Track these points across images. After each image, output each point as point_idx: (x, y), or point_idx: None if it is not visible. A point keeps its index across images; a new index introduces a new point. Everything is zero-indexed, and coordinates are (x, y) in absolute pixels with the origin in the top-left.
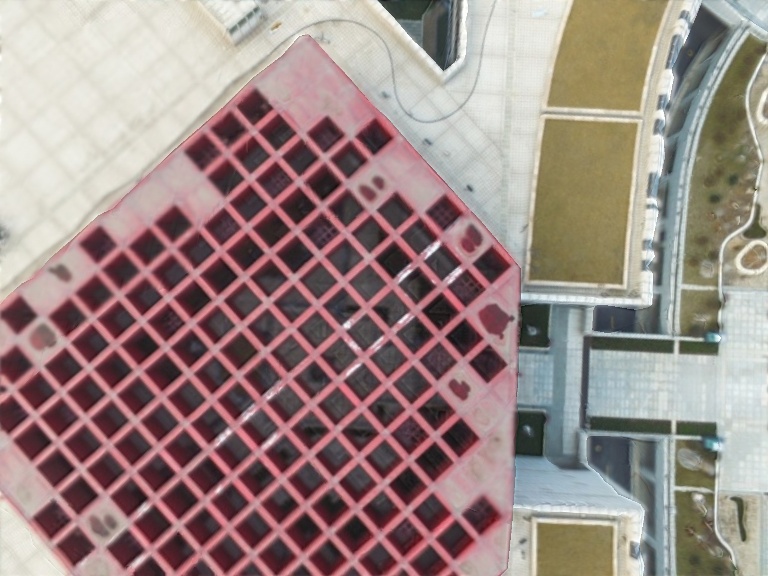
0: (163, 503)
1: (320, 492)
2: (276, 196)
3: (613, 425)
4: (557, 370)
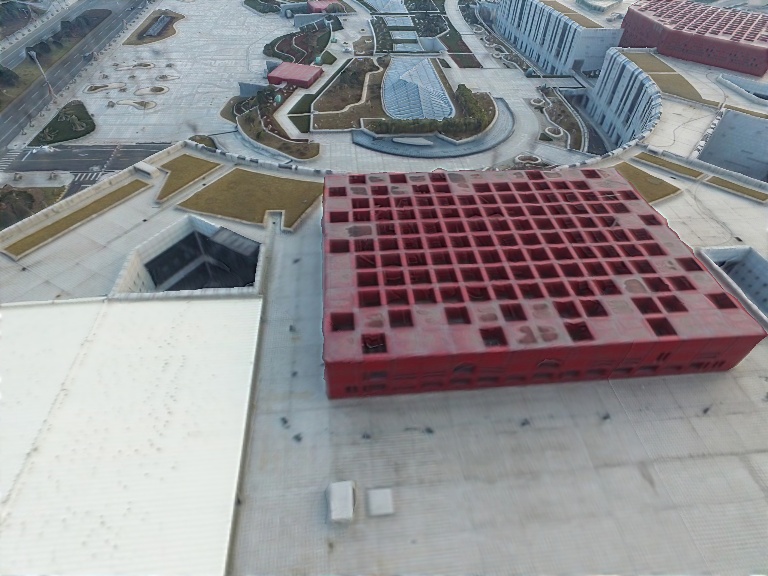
0: None
1: None
2: None
3: (563, 76)
4: None
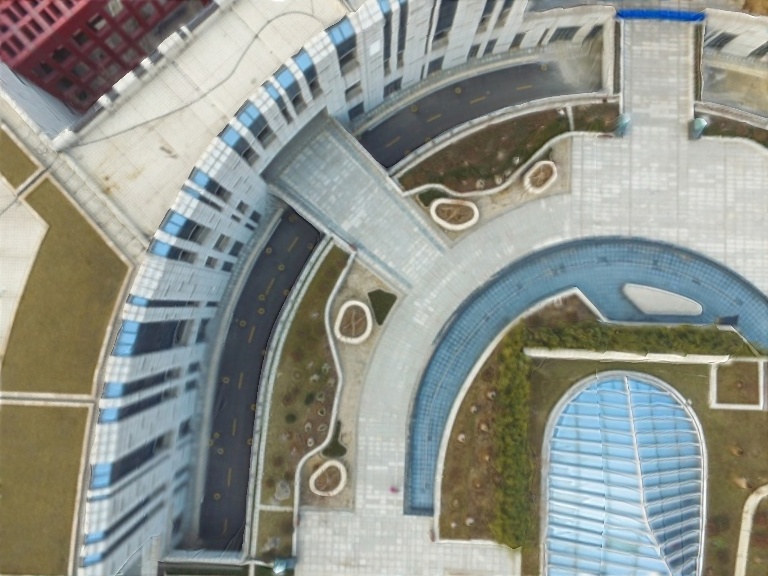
0: None
1: None
2: None
3: None
4: None
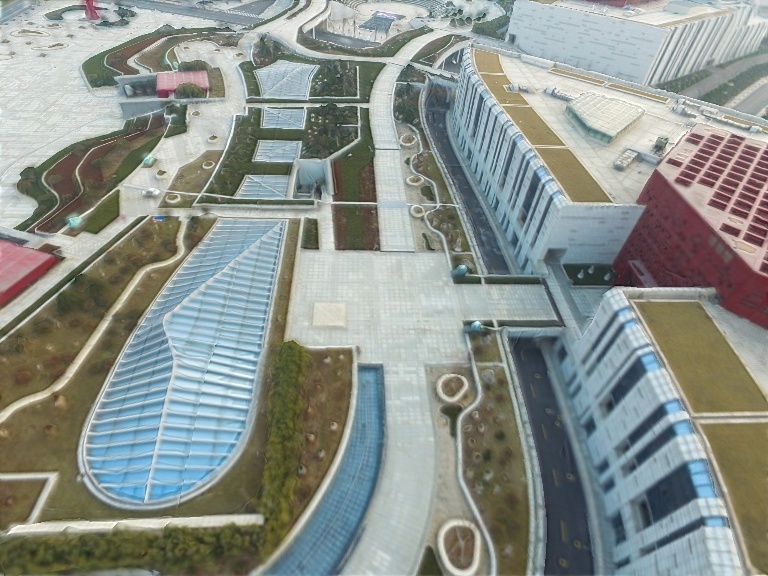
0: None
1: (765, 188)
2: None
3: (524, 280)
4: (575, 308)
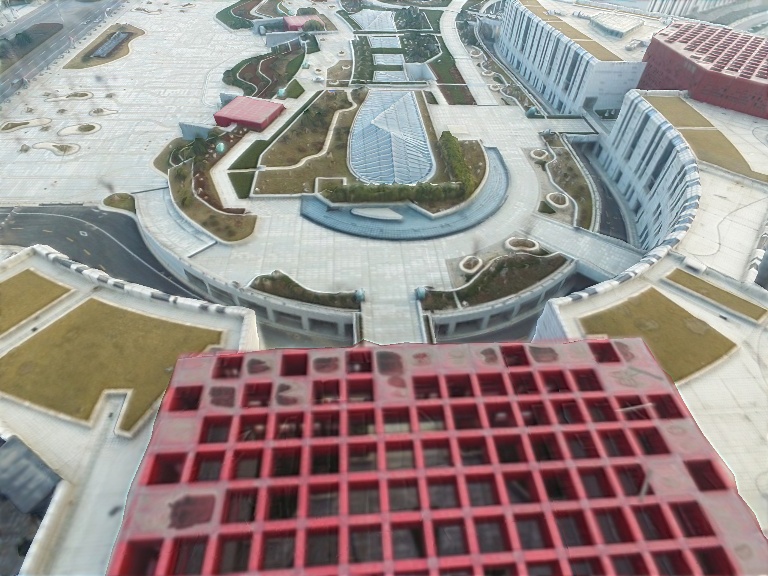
0: (759, 42)
1: None
2: None
3: (572, 117)
4: None
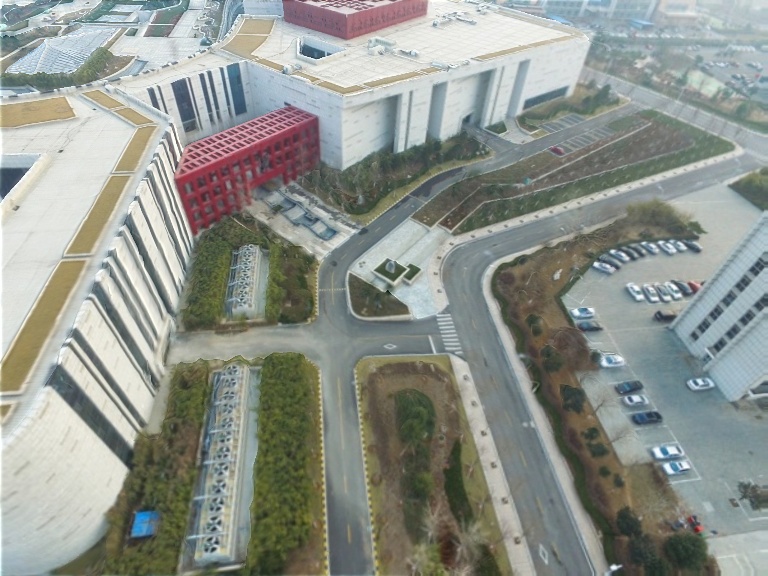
0: None
1: None
2: (349, 2)
3: None
4: None
